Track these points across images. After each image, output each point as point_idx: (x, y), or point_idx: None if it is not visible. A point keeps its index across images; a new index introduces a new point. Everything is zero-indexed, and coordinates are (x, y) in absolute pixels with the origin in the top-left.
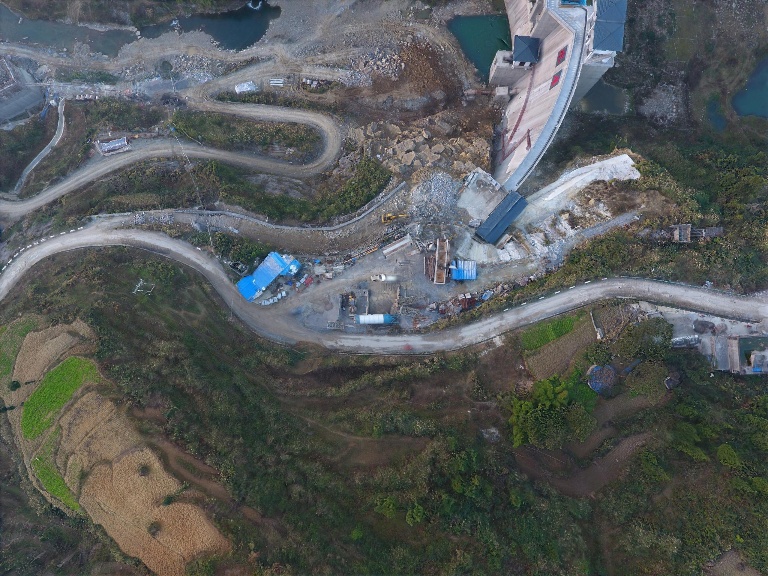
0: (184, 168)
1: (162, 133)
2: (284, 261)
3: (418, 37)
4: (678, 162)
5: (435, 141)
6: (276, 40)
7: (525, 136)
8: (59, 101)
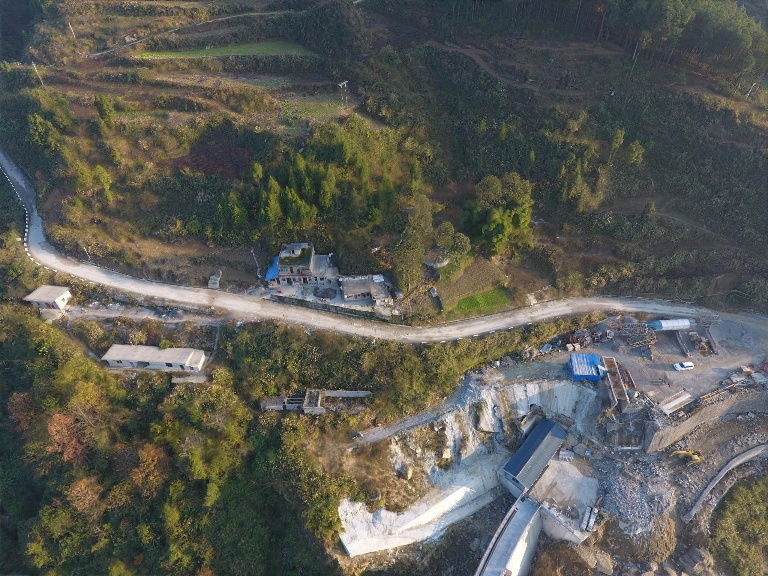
0: None
1: None
2: None
3: None
4: (243, 572)
5: None
6: None
7: None
8: None
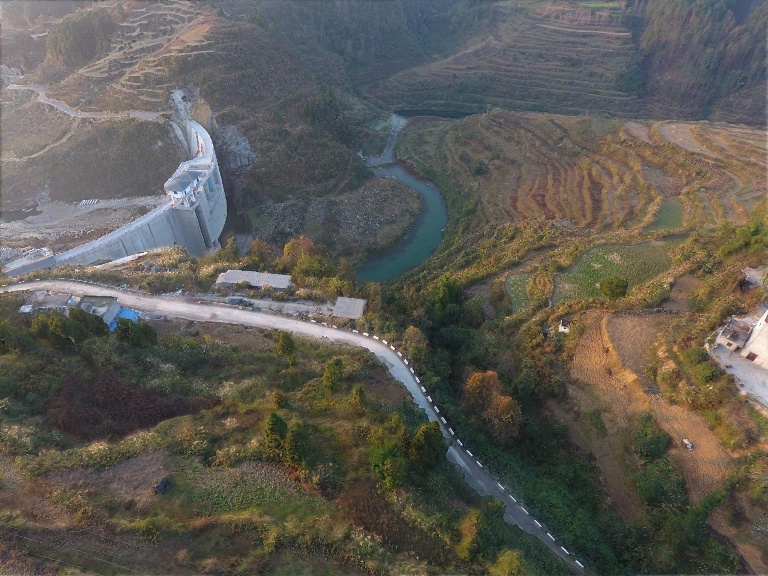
0: None
1: None
2: None
3: None
4: None
5: None
6: (19, 221)
7: None
8: None
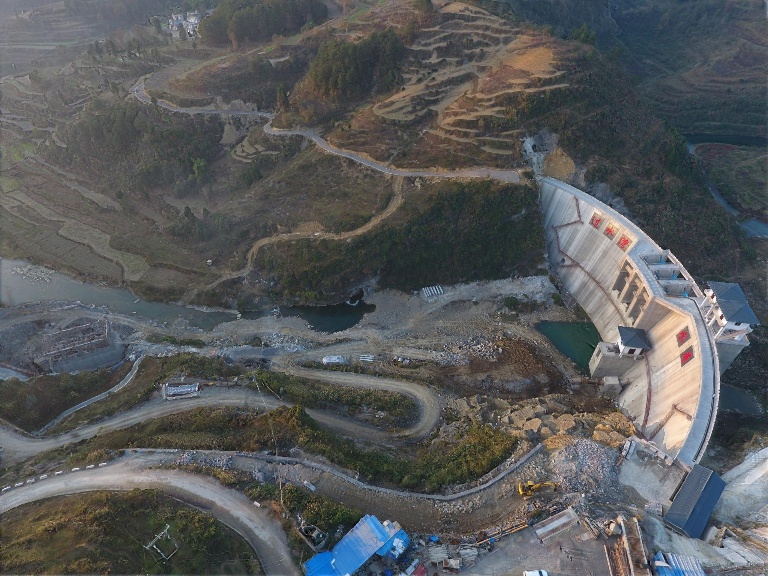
0: (256, 417)
1: (240, 383)
2: (385, 530)
3: (508, 334)
4: None
5: (555, 416)
6: (370, 326)
7: (672, 411)
8: (139, 357)
